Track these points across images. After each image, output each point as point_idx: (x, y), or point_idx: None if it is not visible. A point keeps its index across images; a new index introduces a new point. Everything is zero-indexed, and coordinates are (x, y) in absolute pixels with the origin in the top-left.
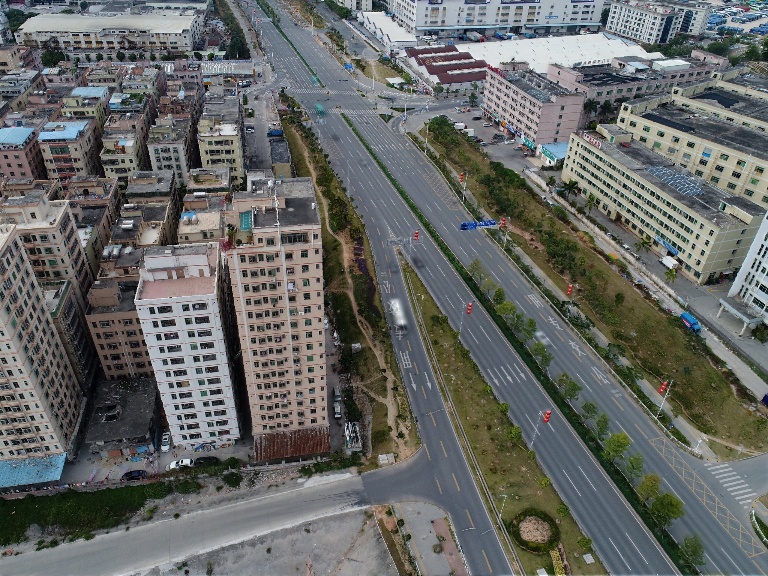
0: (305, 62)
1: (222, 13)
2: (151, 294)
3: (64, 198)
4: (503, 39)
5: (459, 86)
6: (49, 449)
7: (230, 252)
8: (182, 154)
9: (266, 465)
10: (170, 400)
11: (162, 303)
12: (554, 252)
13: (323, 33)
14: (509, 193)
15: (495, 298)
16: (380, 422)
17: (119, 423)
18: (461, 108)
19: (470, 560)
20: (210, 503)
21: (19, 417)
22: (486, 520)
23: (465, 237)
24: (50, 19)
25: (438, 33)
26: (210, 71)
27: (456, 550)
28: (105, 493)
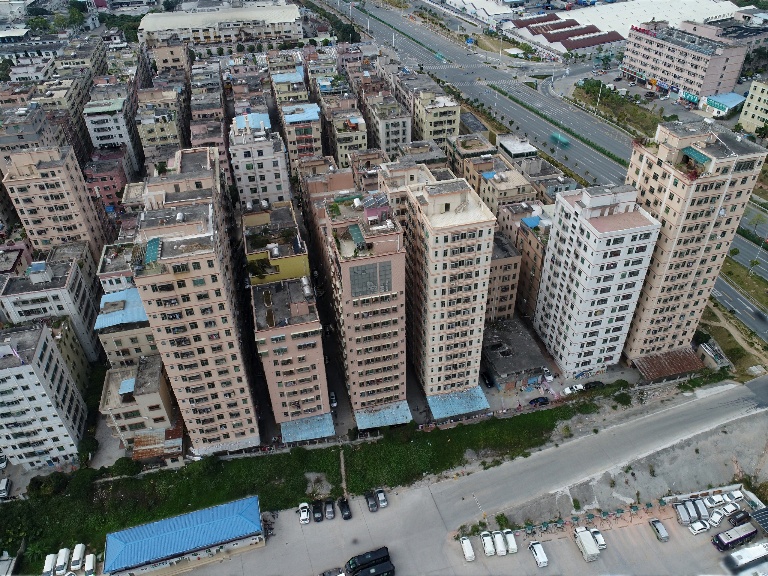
0: (417, 41)
1: (303, 1)
2: (600, 229)
3: None
4: (587, 5)
5: (583, 51)
6: (468, 383)
7: (692, 182)
8: (409, 127)
9: (650, 384)
10: (583, 329)
11: (619, 235)
12: None
13: (411, 13)
14: None
15: None
16: (728, 342)
17: (517, 357)
18: (596, 71)
19: None
20: (618, 419)
21: (462, 352)
22: None
23: None
24: (163, 18)
25: (523, 4)
26: None
27: None
28: (520, 418)
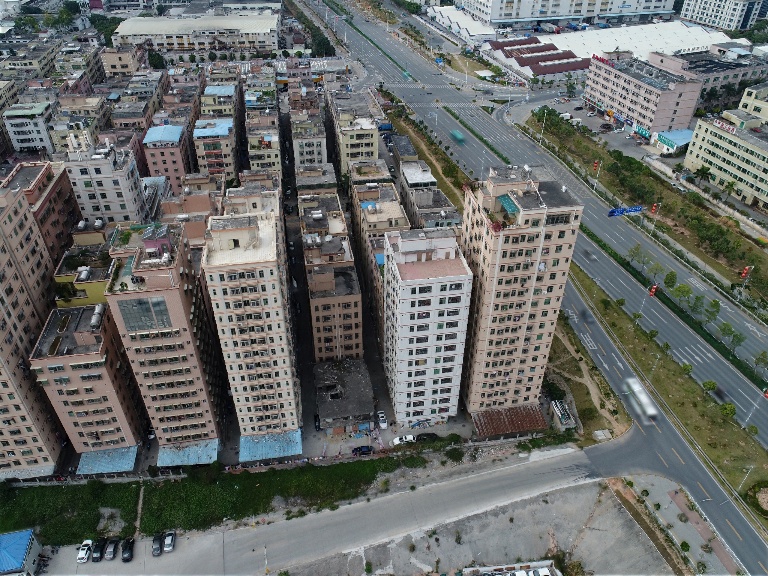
0: (390, 58)
1: (294, 12)
2: (409, 275)
3: None
4: (577, 30)
5: (552, 77)
6: (286, 425)
7: (498, 233)
8: (324, 148)
9: (485, 441)
10: (405, 378)
11: (424, 283)
12: (708, 236)
13: (397, 29)
14: (641, 180)
15: (667, 281)
16: (584, 400)
17: (345, 401)
18: (559, 99)
19: (717, 529)
20: (441, 476)
21: (270, 394)
22: (720, 492)
23: (607, 224)
24: (141, 22)
25: (512, 25)
26: None
27: (701, 519)
28: (339, 467)
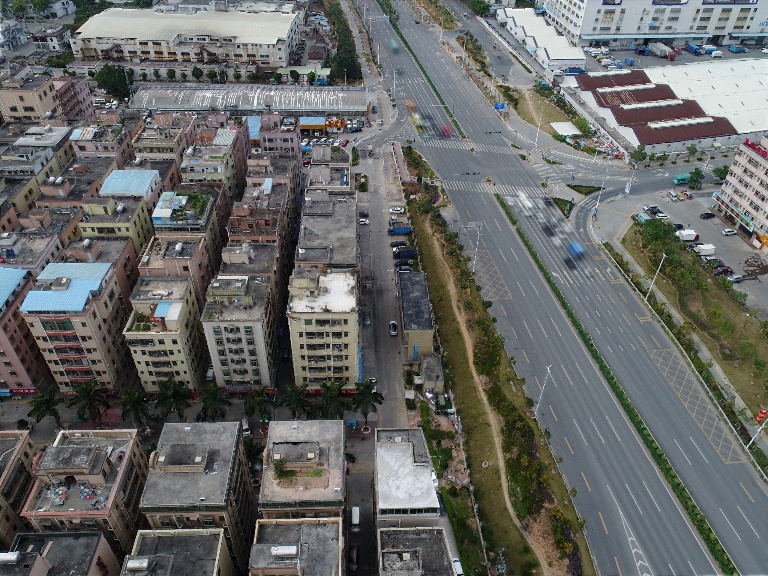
0: (435, 89)
1: (327, 4)
2: None
3: (63, 401)
4: (699, 54)
5: (666, 147)
6: None
7: None
8: (259, 335)
9: None
10: None
11: None
12: None
13: (454, 38)
14: None
15: None
16: None
17: None
18: (676, 190)
19: None
20: None
21: None
22: None
23: None
24: (116, 18)
25: (608, 43)
26: (309, 106)
27: None
28: None
